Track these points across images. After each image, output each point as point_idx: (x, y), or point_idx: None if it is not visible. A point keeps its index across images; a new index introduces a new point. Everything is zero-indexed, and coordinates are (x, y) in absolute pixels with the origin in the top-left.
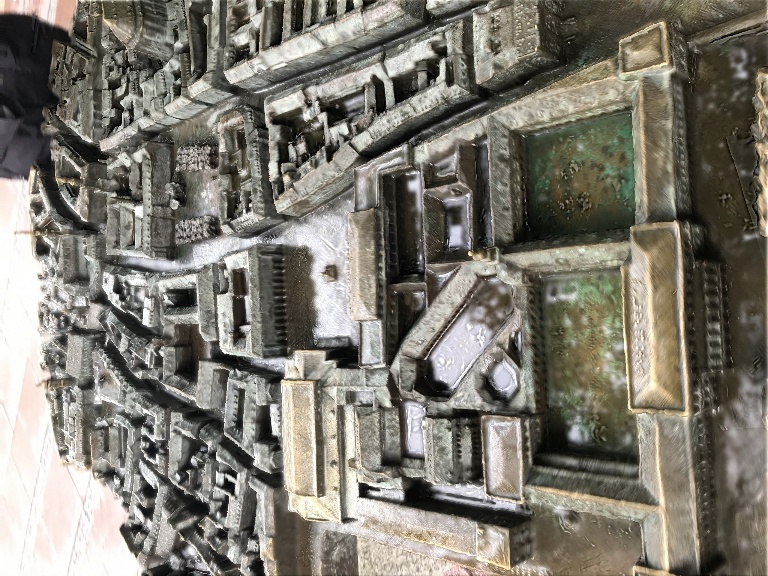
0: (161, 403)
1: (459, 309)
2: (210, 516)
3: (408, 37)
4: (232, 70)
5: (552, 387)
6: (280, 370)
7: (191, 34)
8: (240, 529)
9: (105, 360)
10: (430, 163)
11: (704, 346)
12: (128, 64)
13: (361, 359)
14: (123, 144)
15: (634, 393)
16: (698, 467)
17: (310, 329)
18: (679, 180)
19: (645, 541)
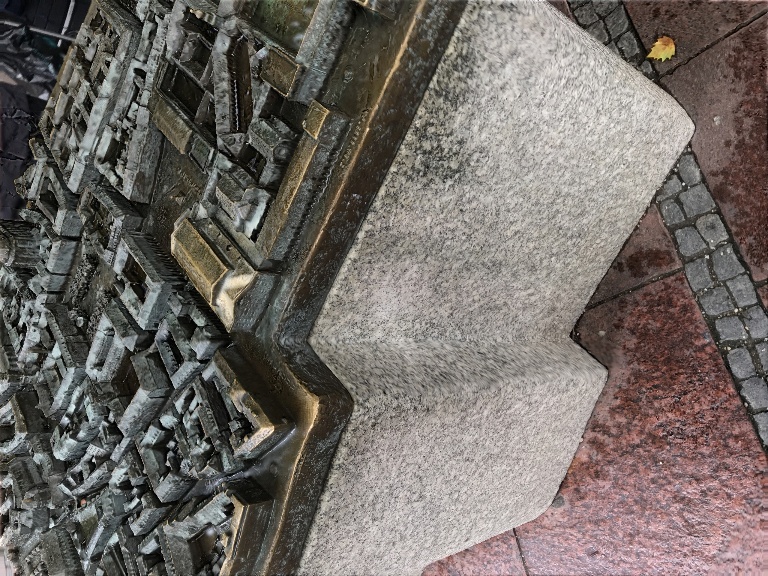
0: None
1: (233, 85)
2: None
3: None
4: (71, 178)
5: (293, 46)
6: None
7: (45, 207)
8: (220, 430)
9: None
10: (175, 52)
11: None
12: None
13: (202, 168)
14: None
15: None
16: None
17: None
18: None
19: None
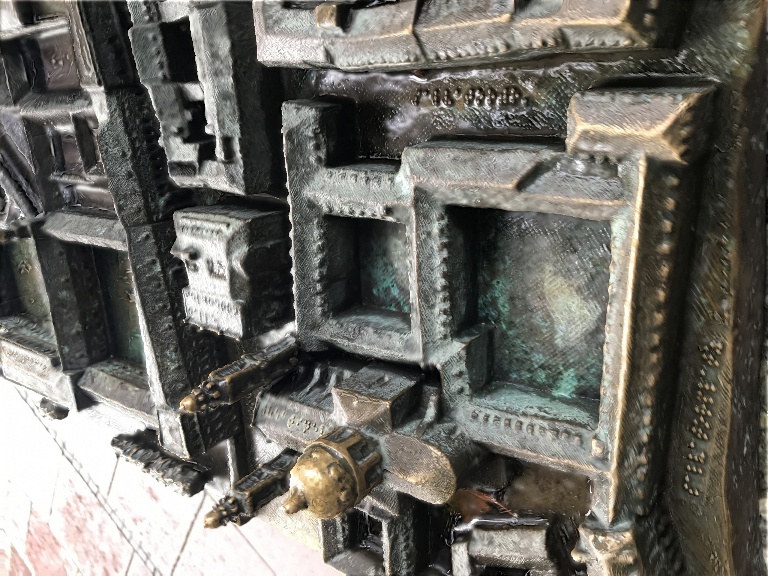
0: None
1: None
2: None
3: None
4: None
5: None
6: None
7: None
8: None
9: None
10: None
11: None
12: None
13: None
14: None
15: (1, 343)
16: None
17: None
18: None
19: None
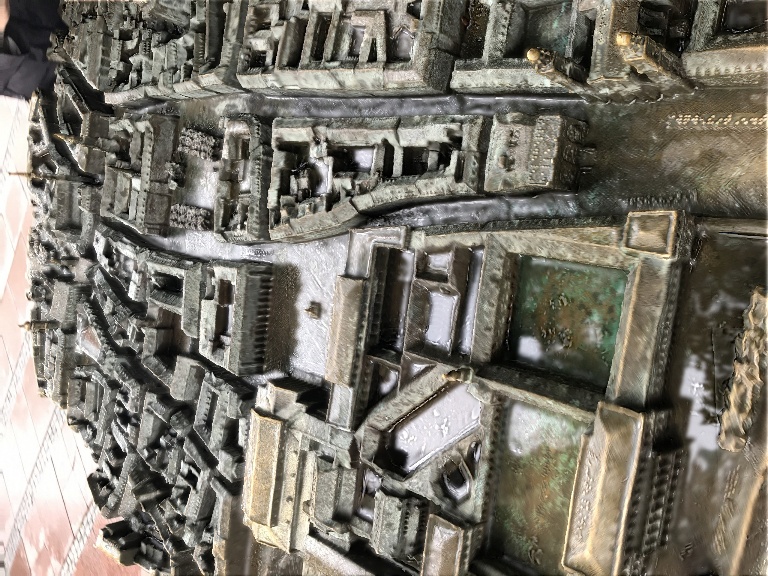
0: (138, 377)
1: (429, 398)
2: (171, 501)
3: (428, 101)
4: (245, 77)
5: (501, 498)
6: (254, 384)
7: (209, 17)
8: (197, 519)
9: (89, 315)
10: (425, 252)
11: (642, 530)
12: None
13: (329, 416)
14: (128, 102)
15: (569, 553)
16: None
17: (288, 355)
18: (656, 365)
19: None
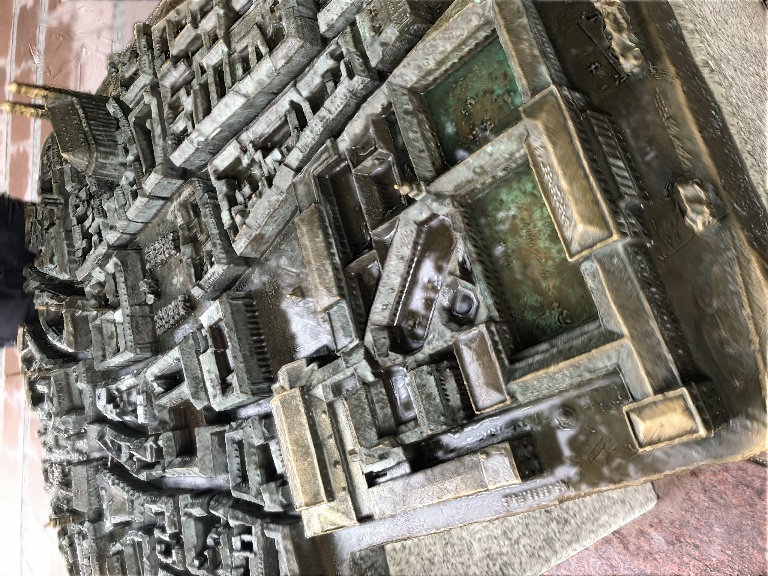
0: (168, 495)
1: (411, 264)
2: None
3: None
4: (176, 152)
5: (510, 297)
6: None
7: (138, 142)
8: None
9: (109, 479)
10: (352, 147)
11: (613, 180)
12: (91, 197)
13: (336, 346)
14: None
15: (568, 244)
16: (648, 292)
17: (291, 356)
18: (549, 62)
19: (626, 382)
